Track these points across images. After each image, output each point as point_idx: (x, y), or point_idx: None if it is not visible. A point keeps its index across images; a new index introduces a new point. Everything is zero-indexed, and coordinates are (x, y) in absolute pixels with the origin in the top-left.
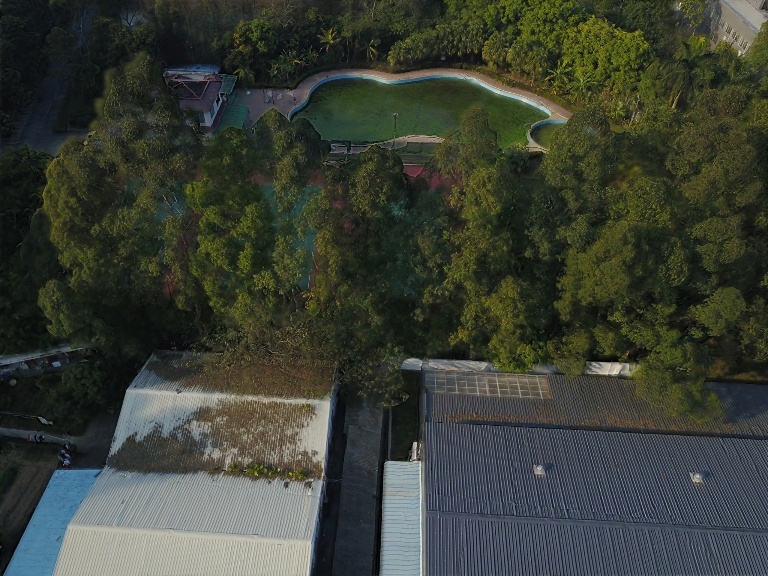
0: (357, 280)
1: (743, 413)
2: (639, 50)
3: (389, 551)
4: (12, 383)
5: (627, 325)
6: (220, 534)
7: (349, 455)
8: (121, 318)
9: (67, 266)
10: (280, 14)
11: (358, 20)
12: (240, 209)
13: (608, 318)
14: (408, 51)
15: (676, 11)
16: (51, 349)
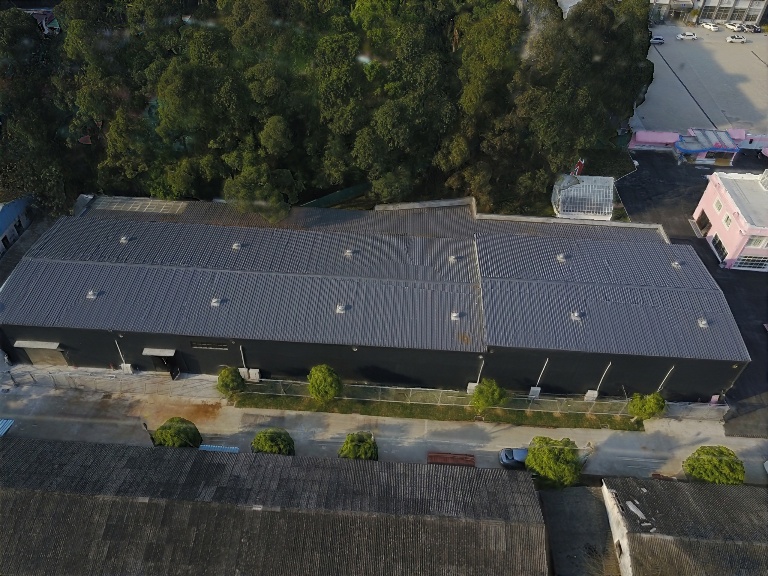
0: (16, 113)
1: (321, 223)
2: None
3: None
4: None
5: (228, 154)
6: None
7: (15, 246)
8: None
9: None
10: None
11: None
12: None
13: (208, 146)
14: None
15: None
16: None
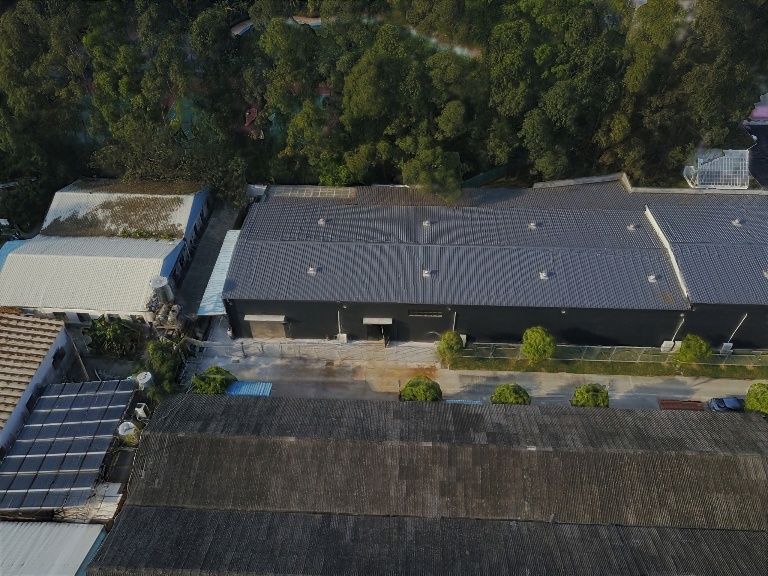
0: (207, 108)
1: (487, 201)
2: None
3: (218, 270)
4: None
5: (400, 139)
6: (105, 256)
7: (208, 232)
8: (53, 149)
9: (11, 104)
10: None
11: None
12: (116, 50)
13: (384, 132)
14: None
15: None
16: (10, 182)
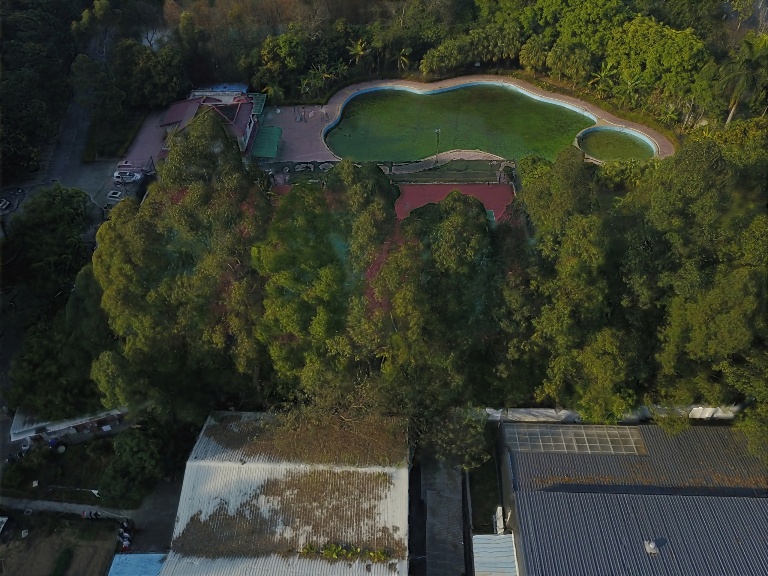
0: (435, 337)
1: None
2: (693, 50)
3: None
4: (61, 450)
5: (733, 373)
6: None
7: (431, 527)
8: (176, 382)
9: (120, 333)
10: (307, 27)
11: (388, 29)
12: (312, 272)
13: (713, 368)
14: (441, 59)
15: (724, 4)
16: (100, 412)
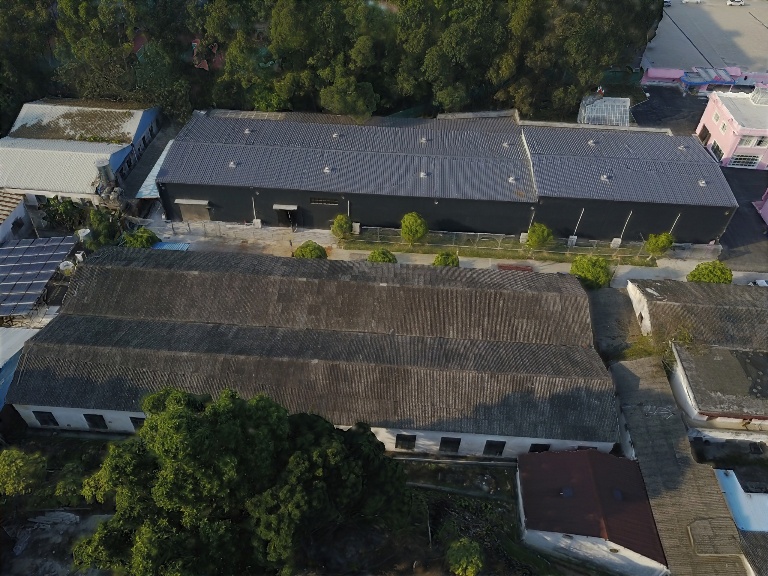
0: (156, 35)
1: (395, 126)
2: None
3: (157, 167)
4: None
5: None
6: (62, 151)
7: (154, 142)
8: (24, 68)
9: None
10: None
11: None
12: None
13: (307, 63)
14: None
15: None
16: None
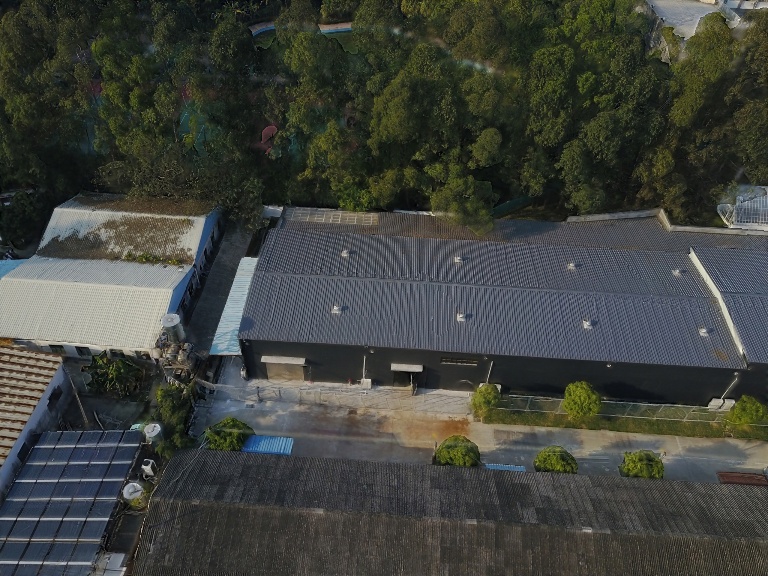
0: (224, 125)
1: (519, 235)
2: None
3: (231, 303)
4: None
5: (430, 166)
6: (109, 284)
7: (219, 258)
8: (53, 160)
9: (10, 111)
10: None
11: None
12: (128, 59)
13: (413, 158)
14: (337, 5)
15: None
16: (4, 193)
